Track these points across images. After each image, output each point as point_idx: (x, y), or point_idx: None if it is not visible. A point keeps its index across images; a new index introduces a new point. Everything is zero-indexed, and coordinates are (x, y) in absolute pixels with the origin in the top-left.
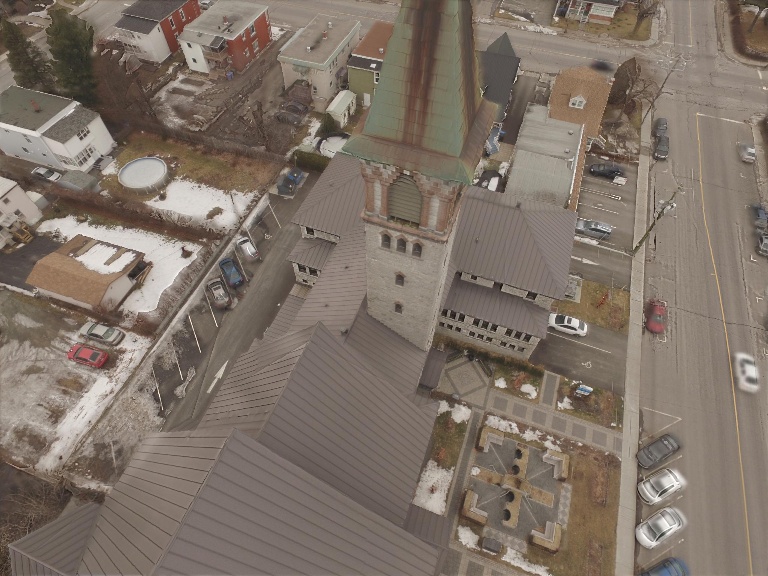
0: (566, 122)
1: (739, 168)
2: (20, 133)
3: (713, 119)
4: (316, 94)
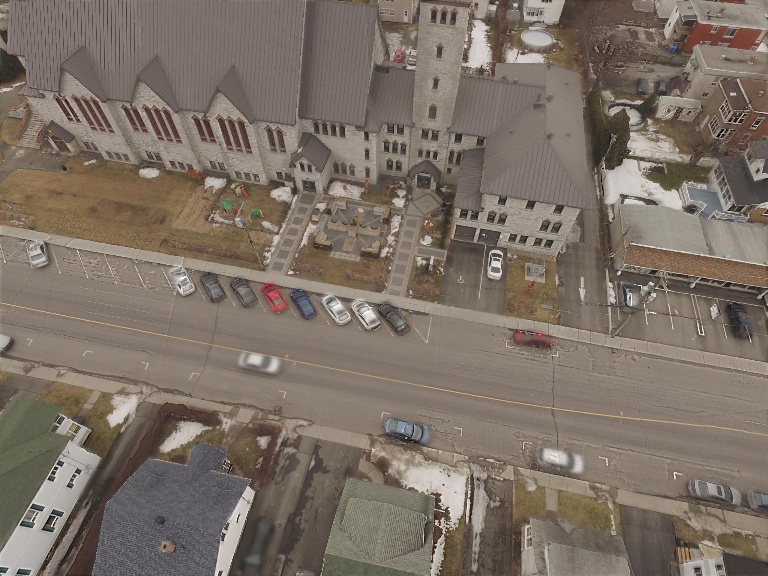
0: None
1: None
2: None
3: None
4: None
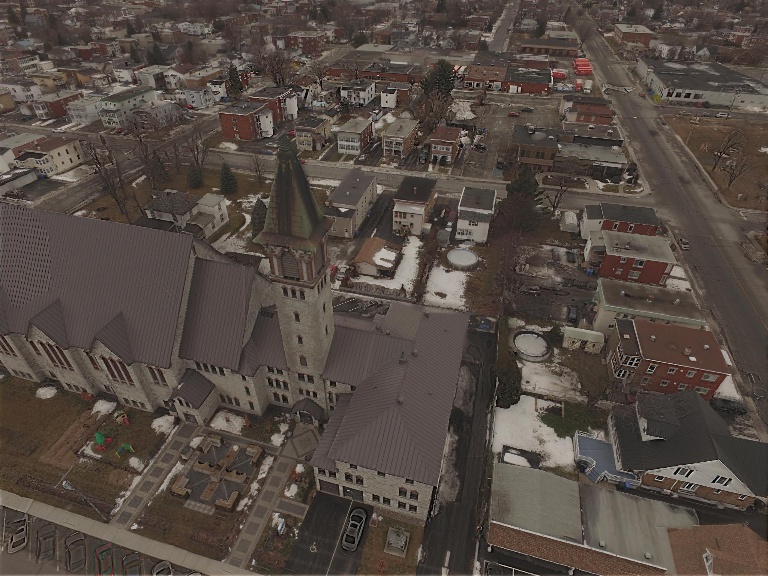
0: (671, 554)
1: None
2: None
3: None
4: (595, 321)
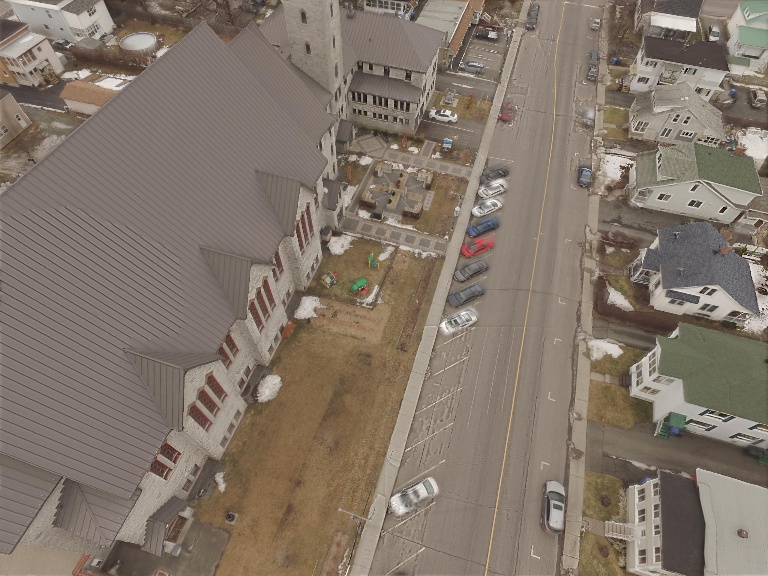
0: (458, 1)
1: (588, 33)
2: (44, 9)
3: (576, 5)
4: None
